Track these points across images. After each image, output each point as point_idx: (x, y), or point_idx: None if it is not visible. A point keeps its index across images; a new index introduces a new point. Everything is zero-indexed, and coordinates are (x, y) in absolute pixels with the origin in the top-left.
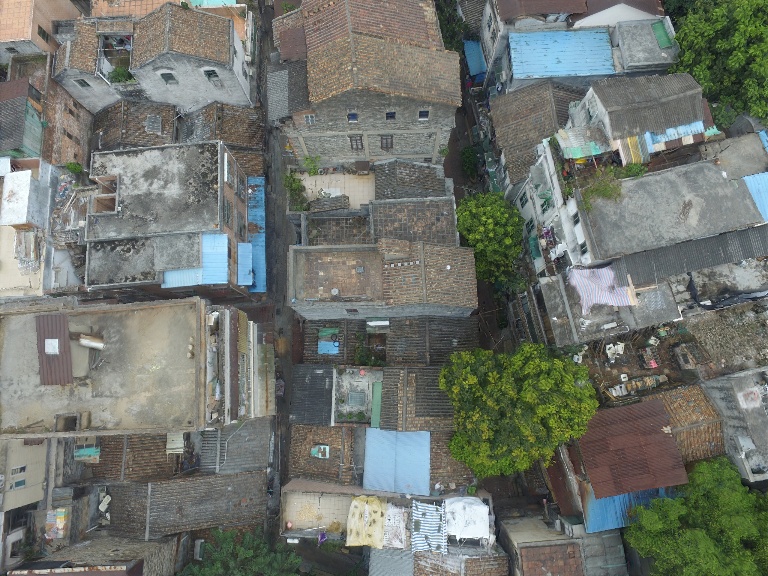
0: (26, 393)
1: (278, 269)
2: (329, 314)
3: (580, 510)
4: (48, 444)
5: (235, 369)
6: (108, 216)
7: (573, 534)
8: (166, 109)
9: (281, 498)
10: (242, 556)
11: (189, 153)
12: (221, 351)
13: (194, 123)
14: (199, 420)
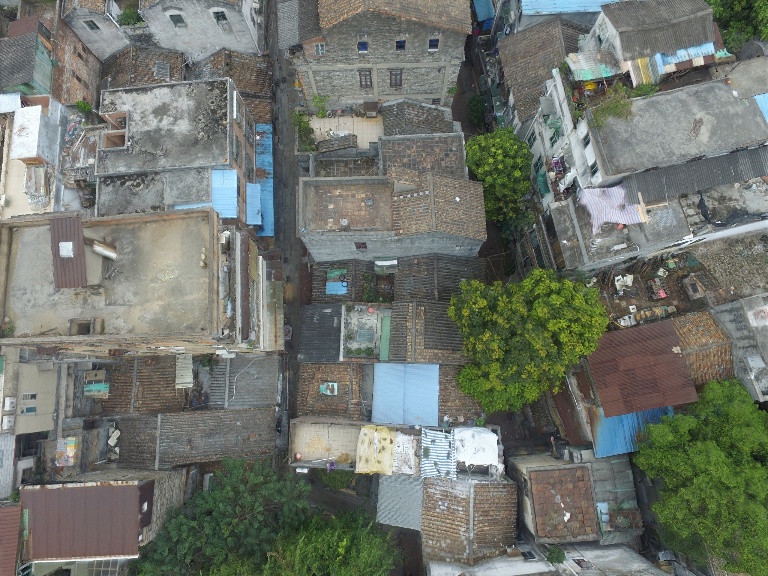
0: (39, 302)
1: (285, 219)
2: (338, 251)
3: (588, 440)
4: (58, 377)
5: (246, 291)
6: (118, 151)
7: (582, 459)
8: (174, 56)
9: (290, 429)
10: (252, 481)
11: (198, 90)
12: (232, 269)
13: (202, 71)
14: (212, 325)
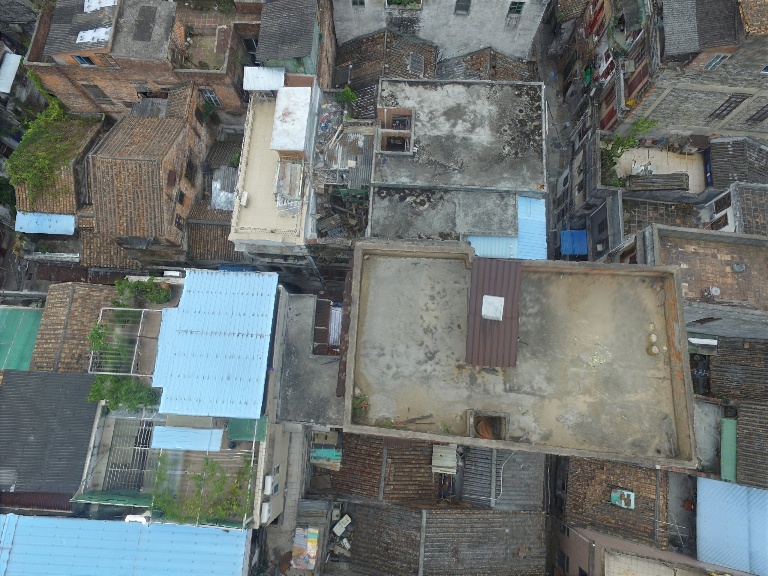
0: (404, 371)
1: None
2: None
3: None
4: (289, 437)
5: None
6: (400, 157)
7: None
8: (428, 49)
9: (602, 559)
10: None
11: (503, 94)
12: None
13: (451, 71)
14: (685, 451)
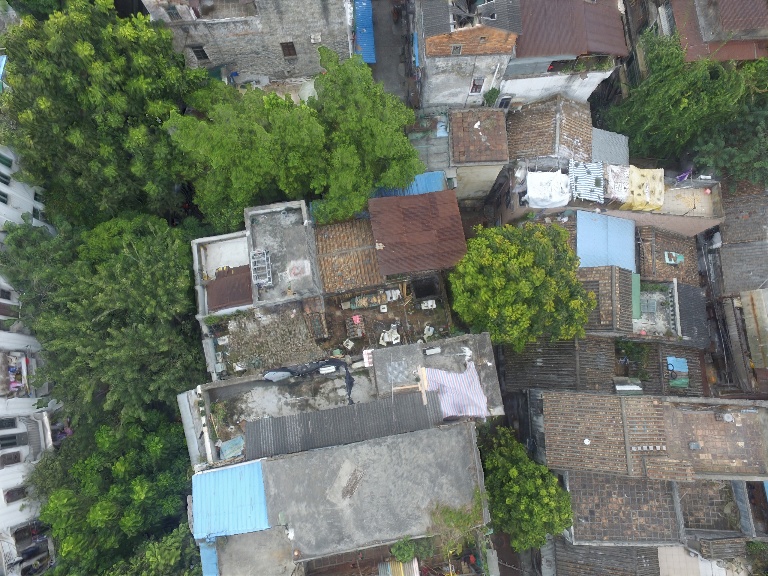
0: None
1: None
2: None
3: None
4: None
5: None
6: None
7: None
8: None
9: None
10: (766, 162)
11: None
12: None
13: None
14: None
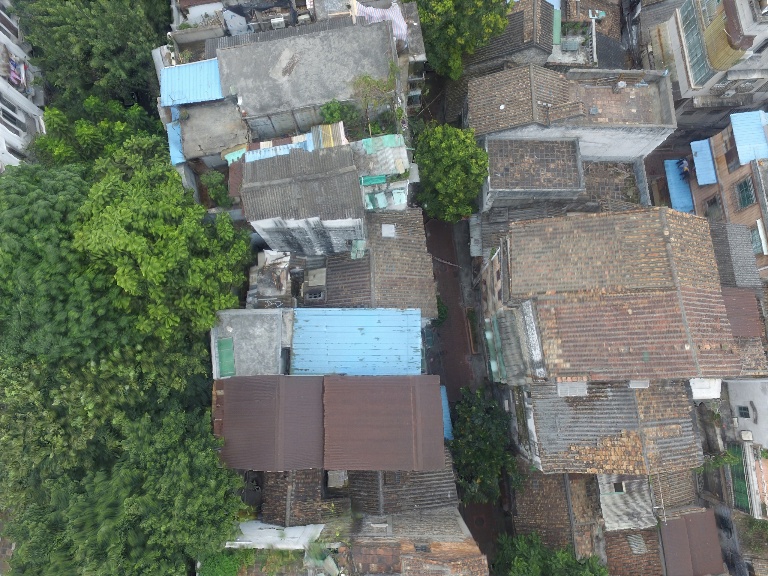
0: None
1: None
2: None
3: None
4: None
5: None
6: None
7: None
8: None
9: None
10: None
11: None
12: None
13: None
14: None
